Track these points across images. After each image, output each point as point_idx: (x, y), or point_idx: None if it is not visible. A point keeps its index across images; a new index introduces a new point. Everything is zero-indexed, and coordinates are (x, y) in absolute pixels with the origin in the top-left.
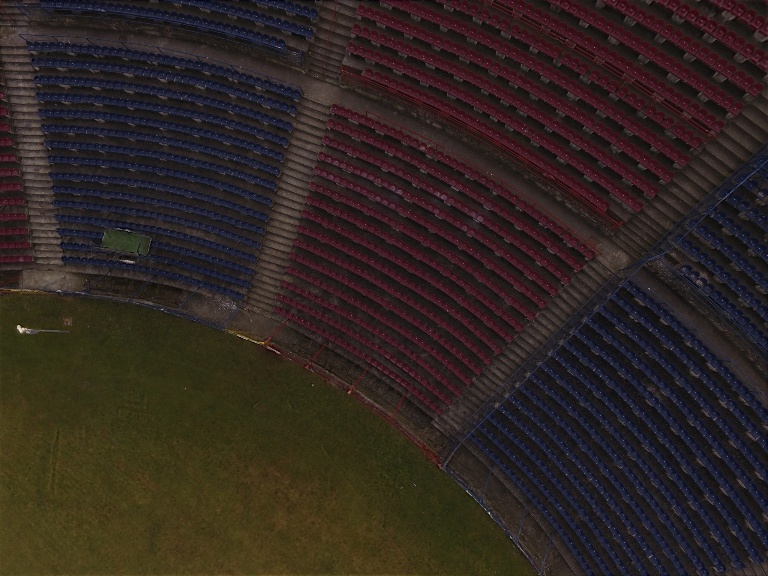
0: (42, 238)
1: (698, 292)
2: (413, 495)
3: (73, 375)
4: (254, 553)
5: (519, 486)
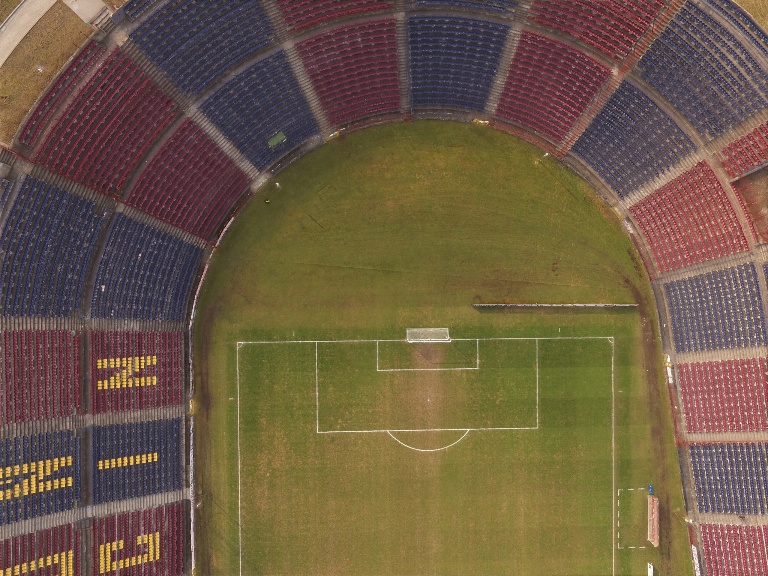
0: (247, 170)
1: (426, 5)
2: (414, 135)
3: (296, 198)
4: (389, 189)
5: (437, 104)
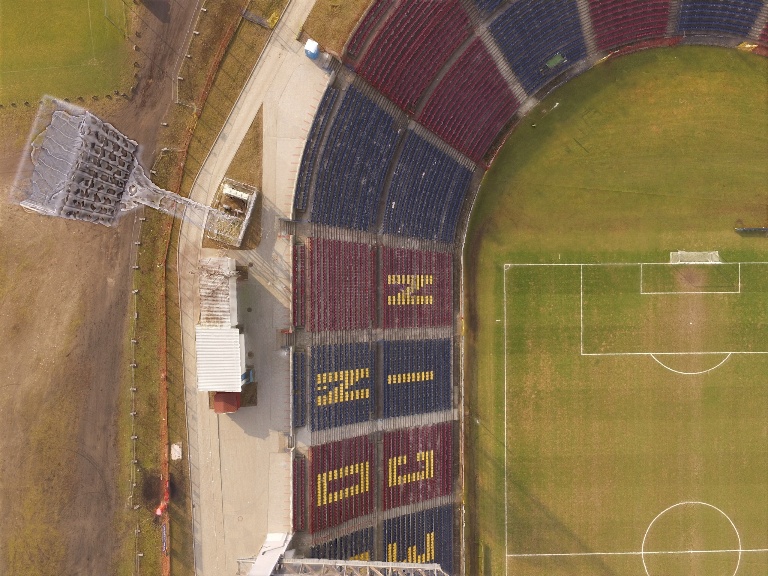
0: (517, 94)
1: None
2: (678, 60)
3: (561, 122)
4: (653, 114)
5: (702, 29)
